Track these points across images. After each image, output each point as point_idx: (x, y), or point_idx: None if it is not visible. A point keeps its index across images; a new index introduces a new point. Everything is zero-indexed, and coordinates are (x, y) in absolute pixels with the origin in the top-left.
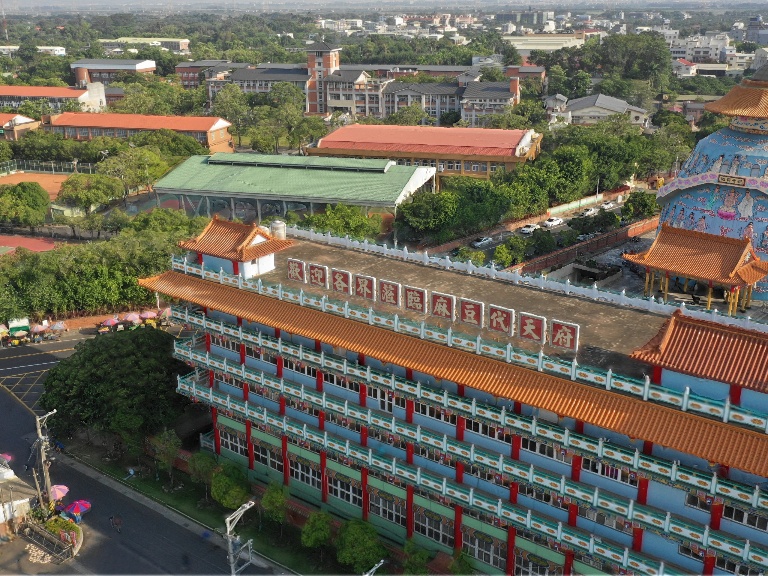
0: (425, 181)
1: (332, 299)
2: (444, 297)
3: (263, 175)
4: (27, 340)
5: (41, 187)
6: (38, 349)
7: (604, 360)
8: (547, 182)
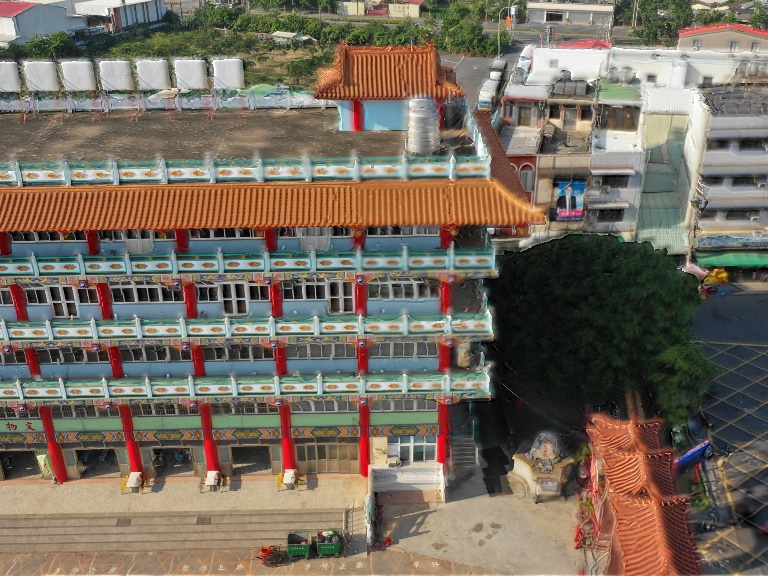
0: None
1: (191, 119)
2: (2, 65)
3: None
4: None
5: None
6: None
7: None
8: None
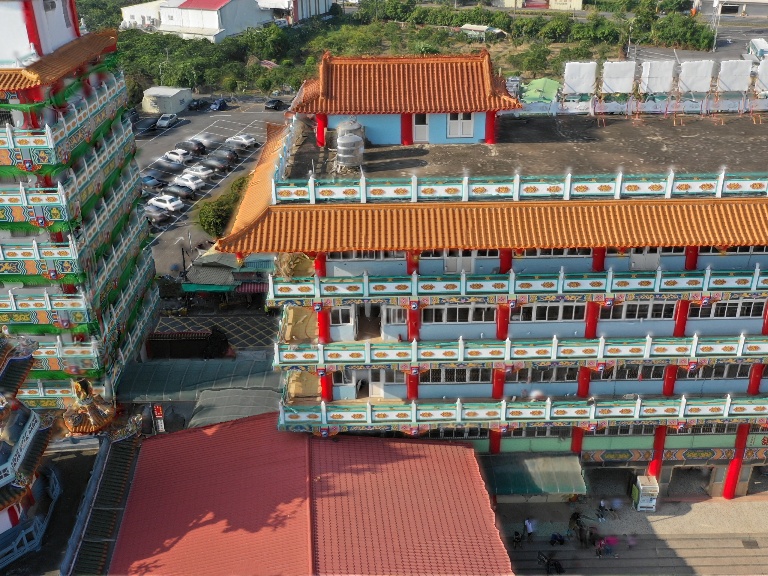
0: None
1: None
2: None
3: None
4: None
5: None
6: None
7: (560, 134)
8: None
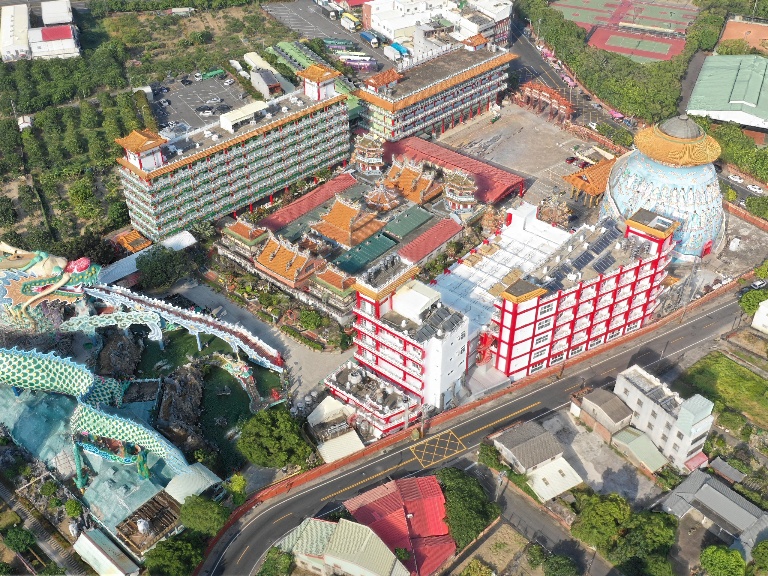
0: (760, 126)
1: None
2: (420, 56)
3: (725, 75)
4: (554, 67)
5: (714, 36)
6: (549, 70)
7: None
8: (765, 162)
